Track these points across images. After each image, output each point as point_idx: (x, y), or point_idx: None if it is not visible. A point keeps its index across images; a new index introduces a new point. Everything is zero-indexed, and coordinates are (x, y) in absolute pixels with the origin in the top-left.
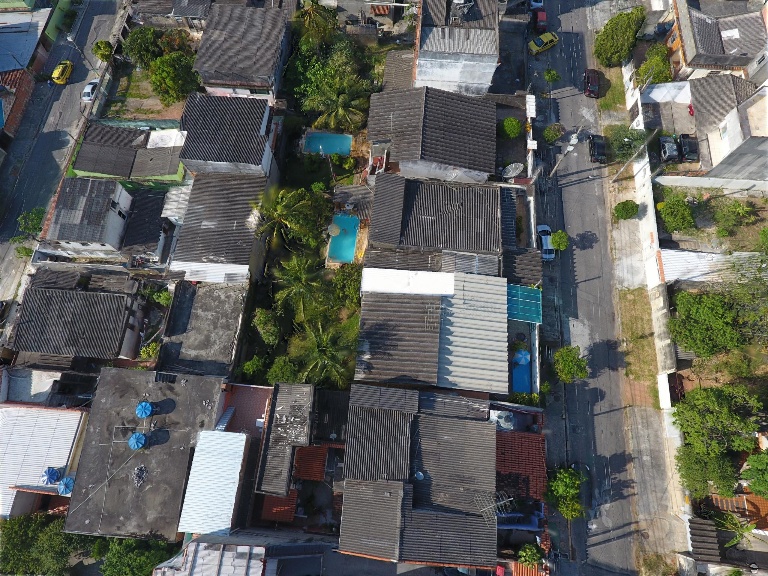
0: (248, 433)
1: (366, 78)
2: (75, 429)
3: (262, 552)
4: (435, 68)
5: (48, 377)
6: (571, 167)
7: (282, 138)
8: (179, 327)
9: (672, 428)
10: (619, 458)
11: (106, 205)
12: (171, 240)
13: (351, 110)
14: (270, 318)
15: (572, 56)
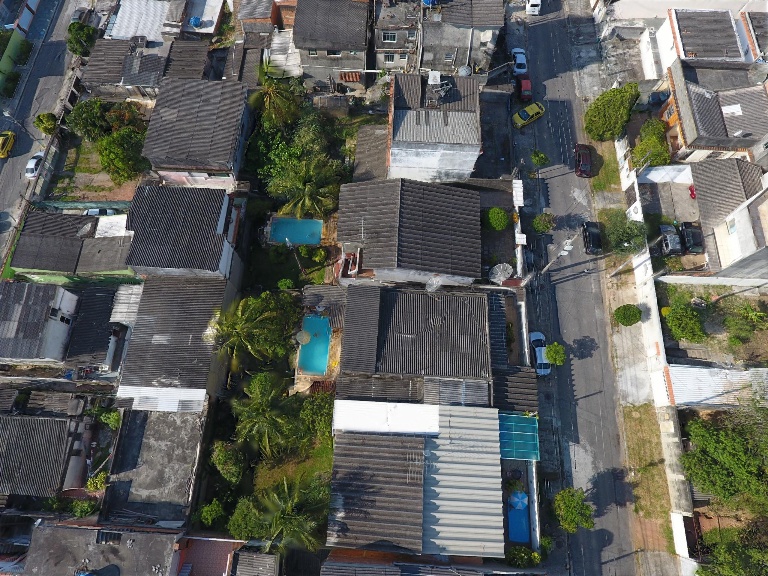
0: None
1: (337, 153)
2: None
3: None
4: (411, 156)
5: None
6: (564, 260)
7: (245, 225)
8: (128, 461)
9: None
10: None
11: (45, 314)
12: (123, 344)
13: (319, 199)
14: (231, 456)
15: (560, 128)
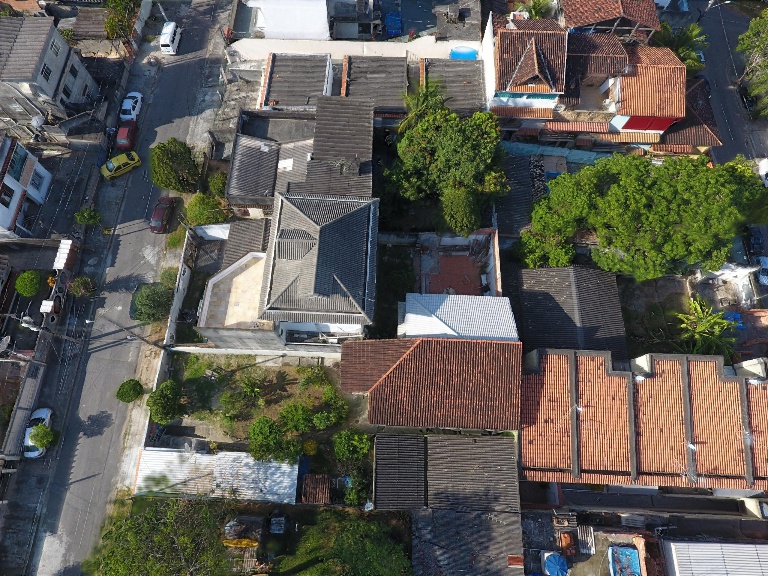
0: None
1: None
2: None
3: None
4: None
5: None
6: (109, 325)
7: None
8: None
9: None
10: None
11: None
12: None
13: None
14: None
15: None
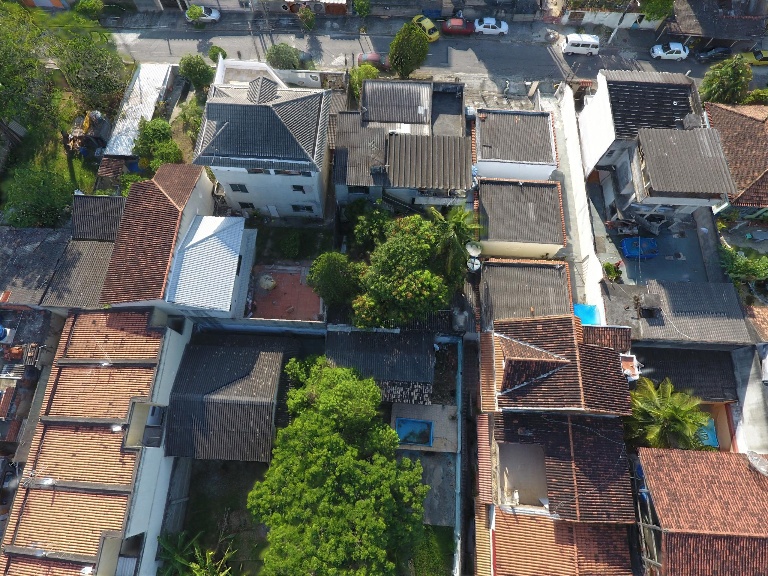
0: None
1: None
2: None
3: None
4: None
5: None
6: None
7: None
8: None
9: None
10: None
11: None
12: None
13: None
14: None
15: None
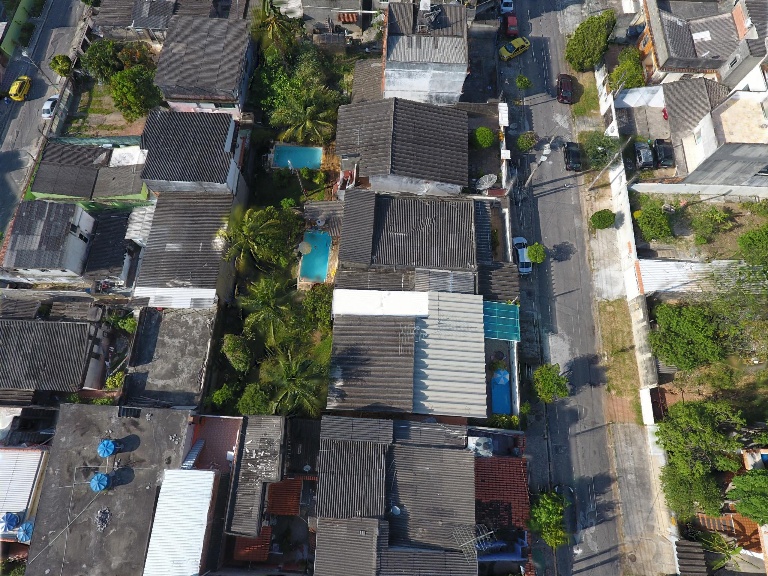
0: (218, 468)
1: (335, 88)
2: (35, 470)
3: None
4: (403, 78)
5: (8, 413)
6: (546, 176)
7: (250, 153)
8: (145, 356)
9: (656, 445)
10: (603, 478)
11: (65, 229)
12: (137, 262)
13: (319, 123)
14: (239, 344)
15: (544, 61)
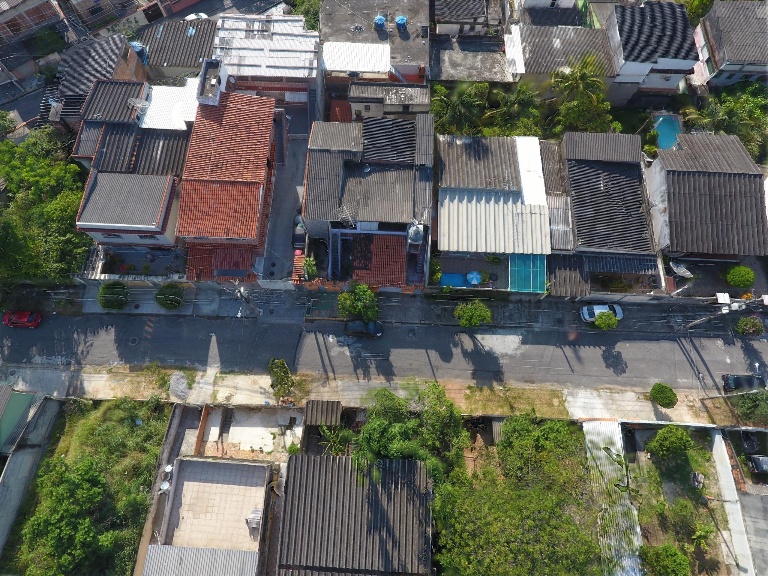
0: None
1: None
2: None
3: (313, 76)
4: None
5: None
6: (708, 354)
7: (663, 97)
8: (465, 46)
9: None
10: (389, 369)
11: None
12: None
13: None
14: (481, 91)
15: None
